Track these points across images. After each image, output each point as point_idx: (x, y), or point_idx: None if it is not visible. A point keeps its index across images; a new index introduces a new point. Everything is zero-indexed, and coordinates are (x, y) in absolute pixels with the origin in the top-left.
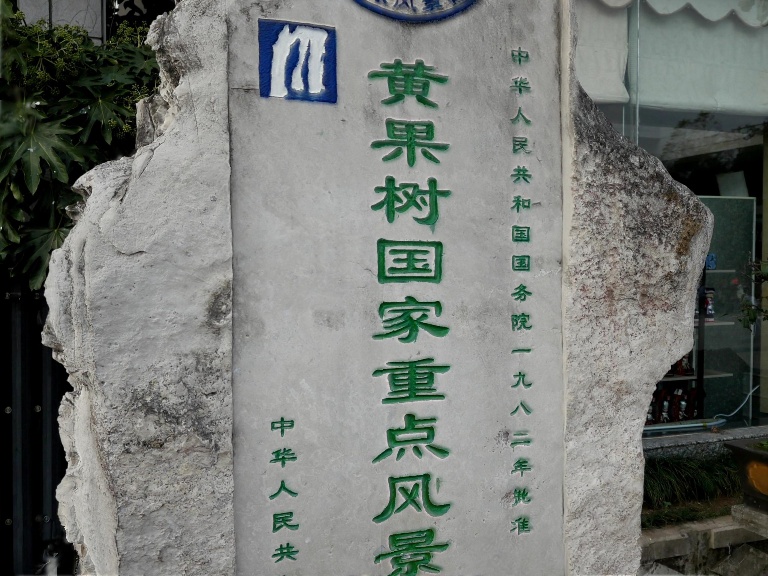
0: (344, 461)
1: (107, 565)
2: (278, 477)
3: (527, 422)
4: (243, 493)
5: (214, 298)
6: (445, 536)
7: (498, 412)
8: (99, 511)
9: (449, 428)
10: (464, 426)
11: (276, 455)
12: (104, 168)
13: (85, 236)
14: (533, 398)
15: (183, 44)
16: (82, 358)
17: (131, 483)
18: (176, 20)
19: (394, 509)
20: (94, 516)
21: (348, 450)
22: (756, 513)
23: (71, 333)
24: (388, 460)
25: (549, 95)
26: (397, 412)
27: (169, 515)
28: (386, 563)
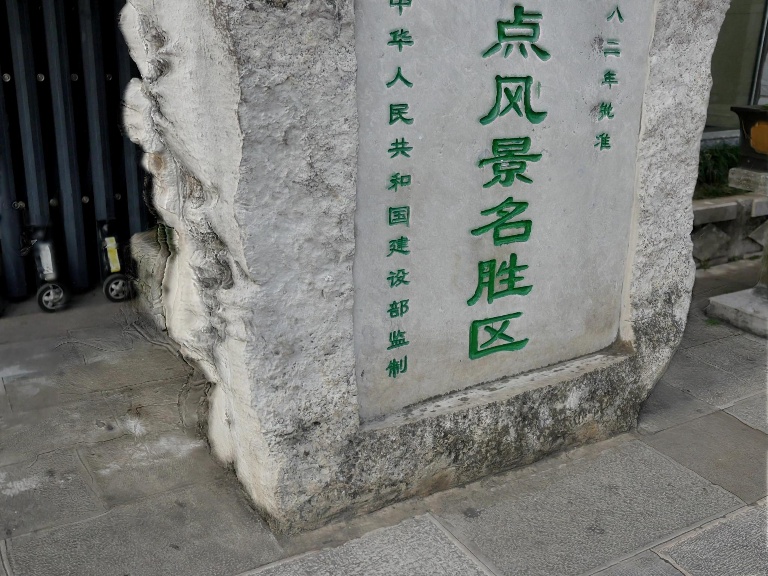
0: (457, 52)
1: (222, 151)
2: (395, 63)
3: (620, 30)
4: (361, 77)
5: None
6: (540, 145)
7: (596, 16)
8: (209, 88)
9: (553, 27)
10: (566, 27)
11: (393, 36)
12: None
13: None
14: (627, 4)
15: None
16: None
17: (254, 48)
18: None
19: (499, 111)
20: (201, 96)
21: (461, 40)
22: (748, 172)
23: None
24: (497, 56)
25: None
26: (509, 1)
27: (293, 91)
28: (489, 168)
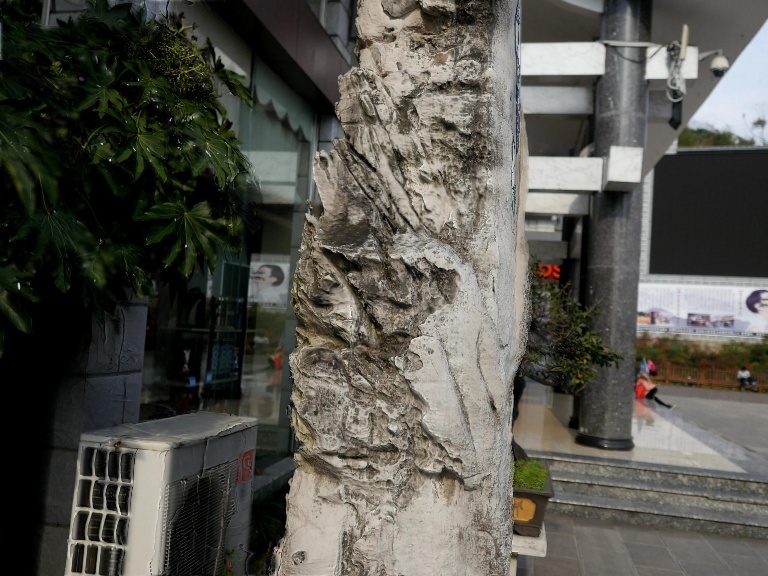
0: None
1: None
2: None
3: None
4: None
5: (510, 388)
6: None
7: None
8: None
9: None
10: None
11: None
12: (446, 249)
13: (480, 327)
14: None
15: (497, 141)
16: (491, 460)
17: None
18: (493, 115)
19: None
20: None
21: None
22: None
23: (469, 434)
24: None
25: (516, 221)
26: None
27: None
28: None
